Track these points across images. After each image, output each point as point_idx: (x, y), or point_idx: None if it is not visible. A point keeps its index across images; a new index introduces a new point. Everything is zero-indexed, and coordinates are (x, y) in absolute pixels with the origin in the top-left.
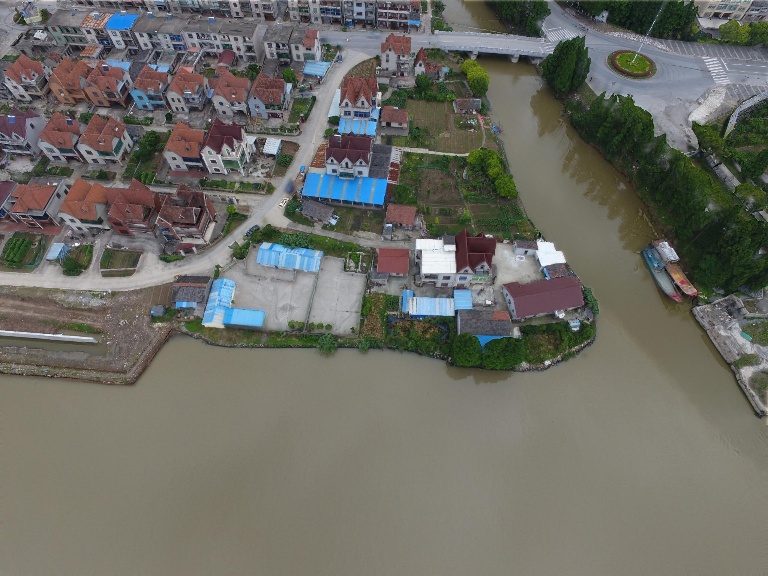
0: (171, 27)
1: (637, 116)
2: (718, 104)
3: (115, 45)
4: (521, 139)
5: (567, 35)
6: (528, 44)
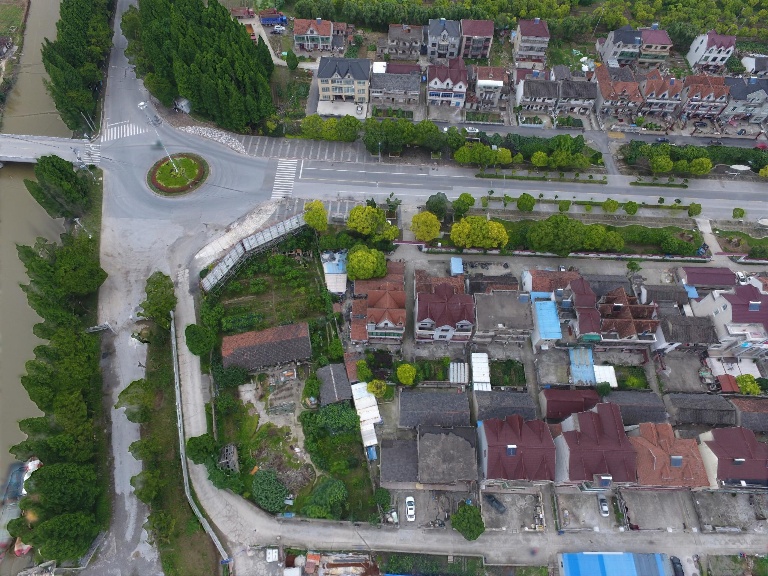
0: None
1: (60, 274)
2: (251, 231)
3: None
4: (17, 276)
5: (128, 132)
6: (66, 147)
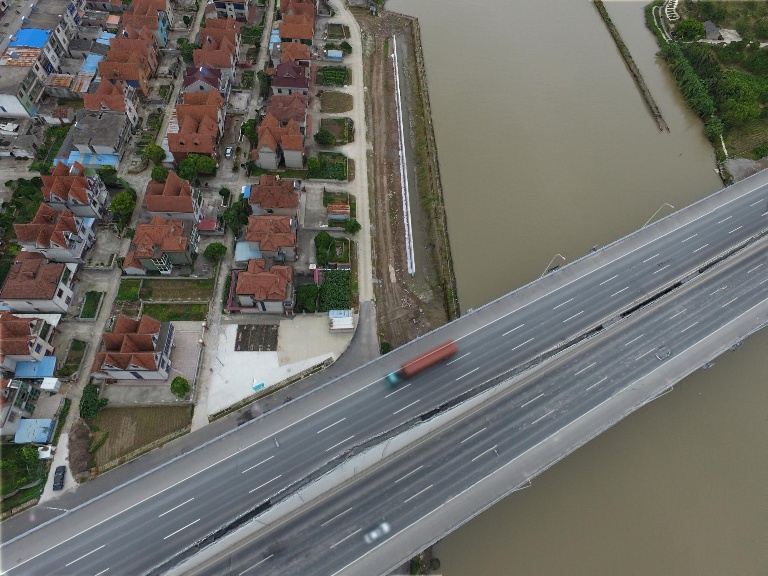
0: (54, 7)
1: None
2: None
3: (53, 66)
4: None
5: None
6: None
